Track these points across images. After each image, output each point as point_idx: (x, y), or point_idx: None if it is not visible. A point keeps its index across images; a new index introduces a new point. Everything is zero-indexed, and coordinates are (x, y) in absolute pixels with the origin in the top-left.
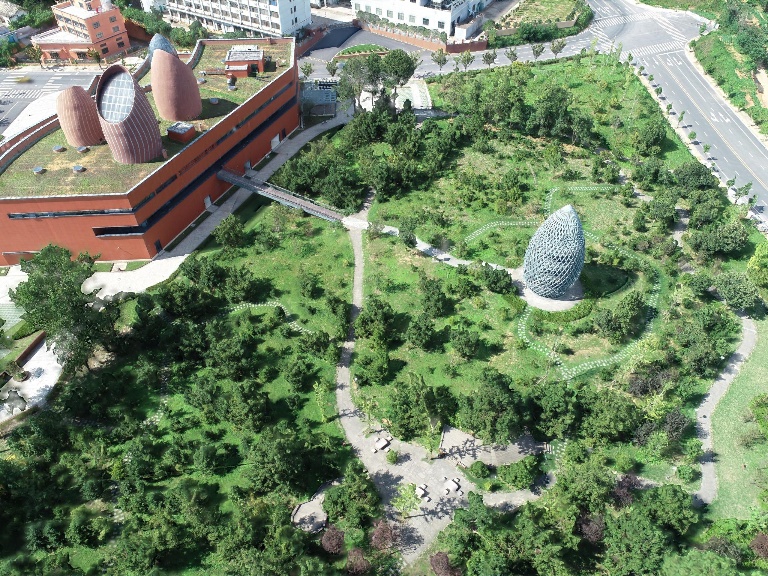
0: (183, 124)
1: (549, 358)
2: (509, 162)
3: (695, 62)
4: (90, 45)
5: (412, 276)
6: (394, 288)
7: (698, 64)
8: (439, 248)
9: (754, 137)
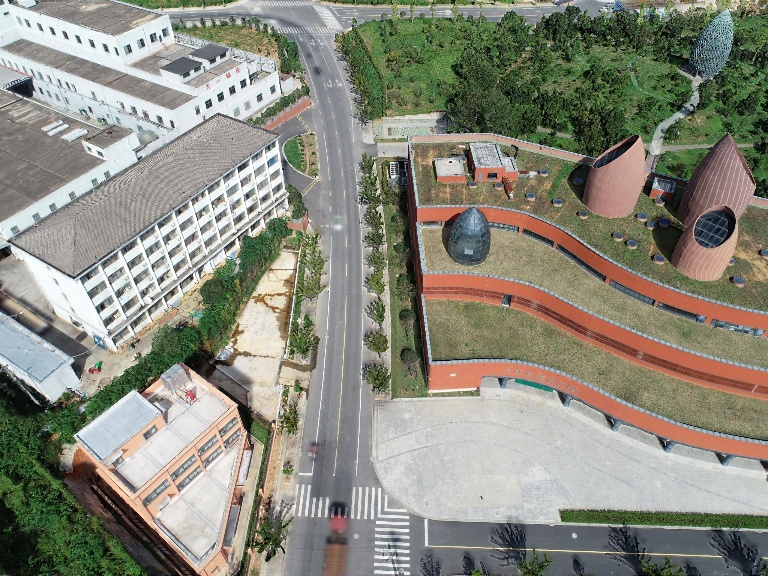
0: (655, 185)
1: (761, 80)
2: (550, 79)
3: (355, 5)
4: (245, 441)
5: (715, 120)
6: (729, 129)
7: (357, 5)
8: (681, 108)
9: (471, 8)
